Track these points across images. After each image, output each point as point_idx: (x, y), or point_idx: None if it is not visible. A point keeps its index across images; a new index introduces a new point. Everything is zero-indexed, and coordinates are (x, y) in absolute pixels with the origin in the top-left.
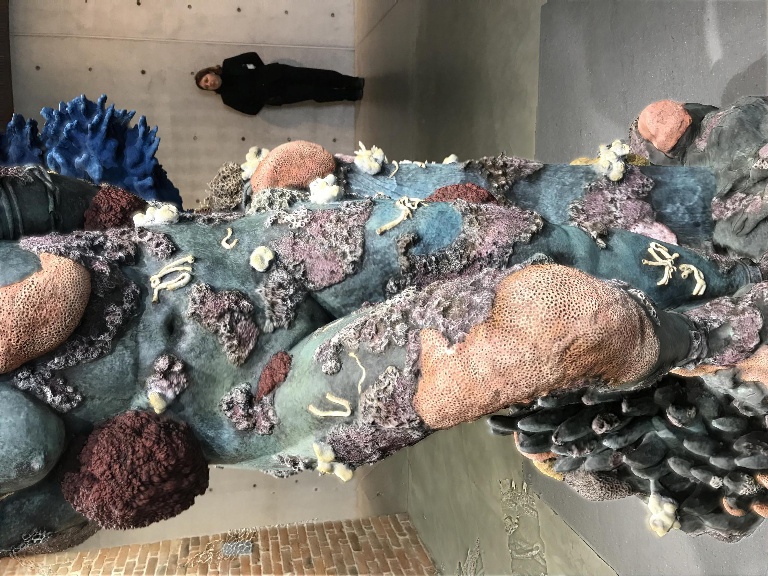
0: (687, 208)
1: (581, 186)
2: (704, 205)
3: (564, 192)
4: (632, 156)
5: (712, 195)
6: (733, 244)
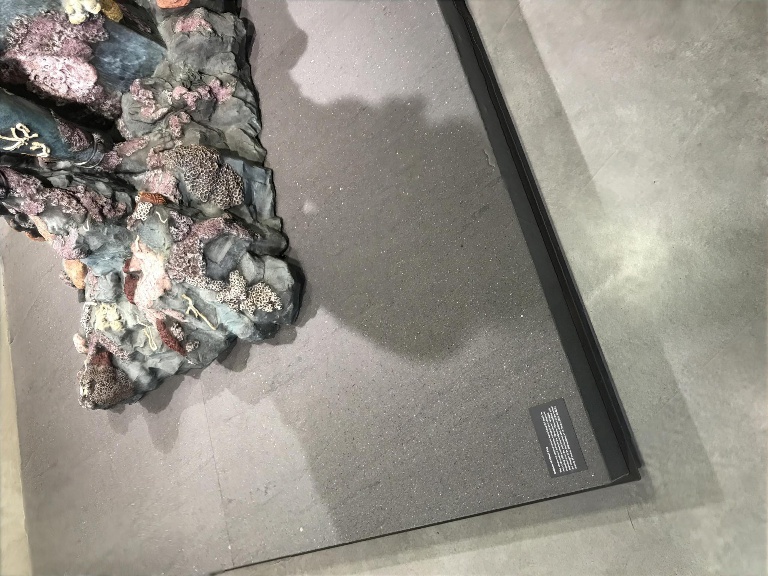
0: (123, 65)
1: (39, 7)
2: (138, 70)
3: (19, 4)
4: (109, 6)
5: (151, 66)
6: (124, 114)
